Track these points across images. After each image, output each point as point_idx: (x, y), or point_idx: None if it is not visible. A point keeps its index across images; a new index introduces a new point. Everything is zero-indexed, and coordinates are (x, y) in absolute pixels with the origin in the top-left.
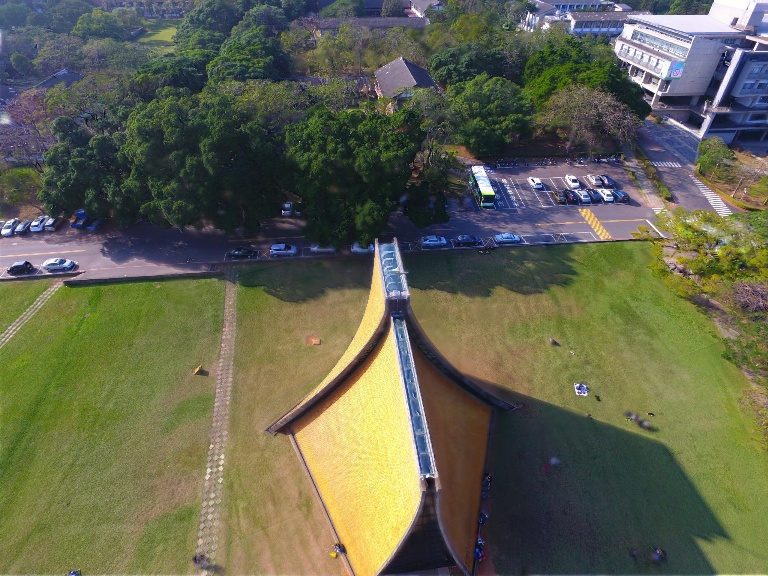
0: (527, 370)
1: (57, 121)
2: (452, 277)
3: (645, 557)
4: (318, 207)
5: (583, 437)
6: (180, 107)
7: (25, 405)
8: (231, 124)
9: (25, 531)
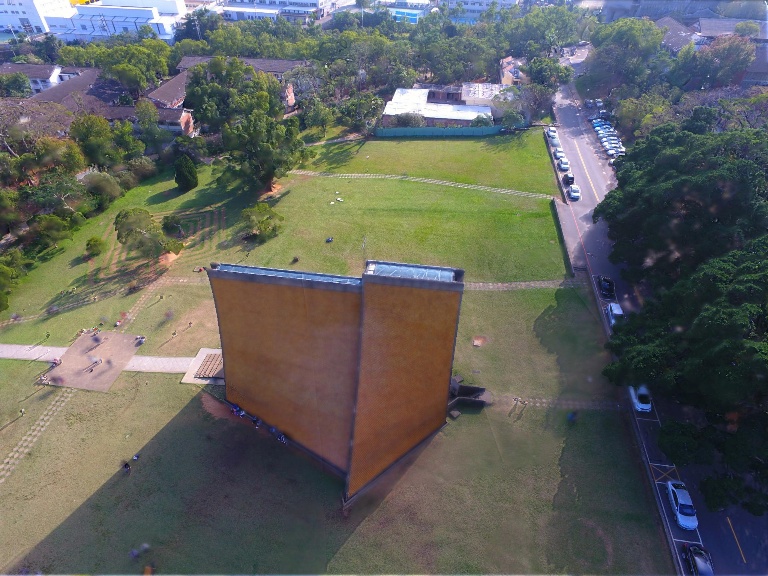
0: (394, 551)
1: (698, 108)
2: (590, 512)
3: (156, 555)
4: (650, 306)
5: (282, 569)
6: (750, 146)
7: (441, 207)
8: (724, 180)
9: (362, 223)
